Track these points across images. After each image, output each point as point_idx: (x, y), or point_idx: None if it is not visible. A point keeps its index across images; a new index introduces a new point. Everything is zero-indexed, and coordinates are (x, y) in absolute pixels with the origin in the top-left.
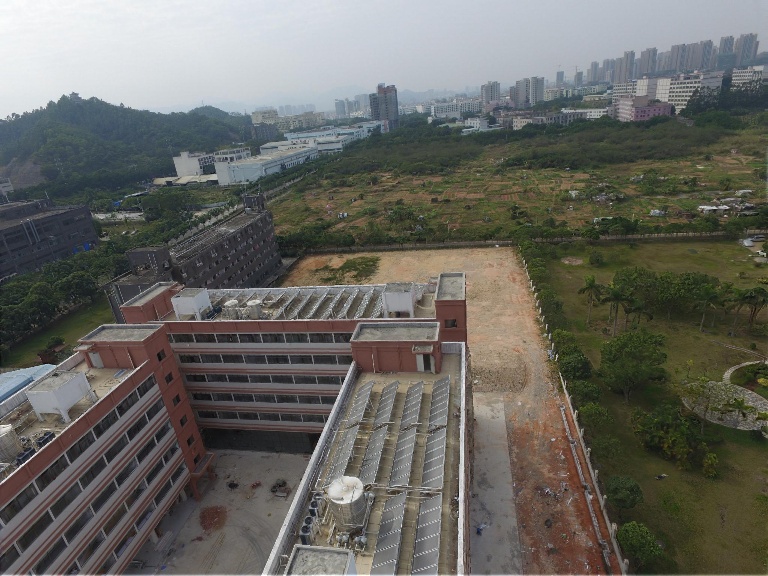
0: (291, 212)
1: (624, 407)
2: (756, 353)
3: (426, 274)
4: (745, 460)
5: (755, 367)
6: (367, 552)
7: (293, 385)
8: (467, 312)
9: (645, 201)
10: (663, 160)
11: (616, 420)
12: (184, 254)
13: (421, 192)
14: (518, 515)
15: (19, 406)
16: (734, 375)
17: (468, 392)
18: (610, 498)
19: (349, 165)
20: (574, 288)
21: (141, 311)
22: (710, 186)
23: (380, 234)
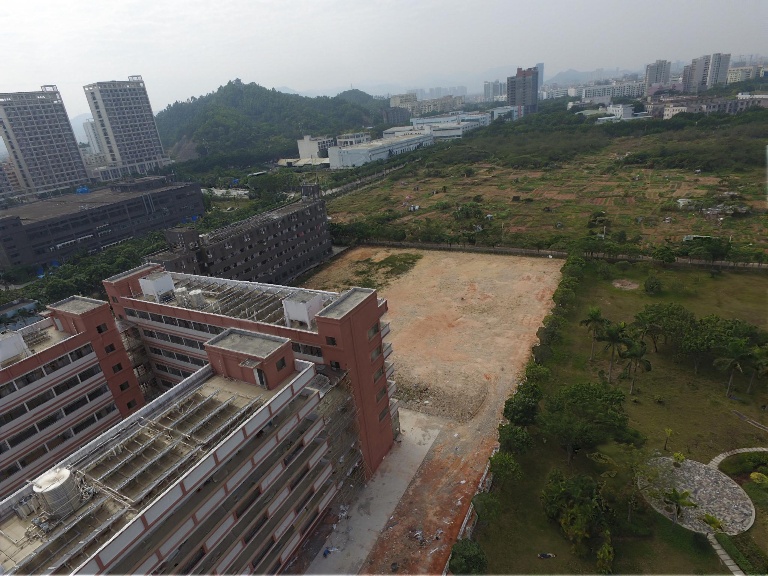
0: (371, 200)
1: (561, 466)
2: None
3: (455, 279)
4: (664, 566)
5: (765, 456)
6: (45, 539)
7: None
8: (466, 326)
9: None
10: None
11: (541, 478)
12: (216, 237)
13: (509, 188)
14: (374, 549)
15: None
16: (727, 460)
17: (334, 413)
18: (449, 561)
19: (454, 154)
20: (604, 317)
21: (114, 287)
22: None
23: (437, 231)
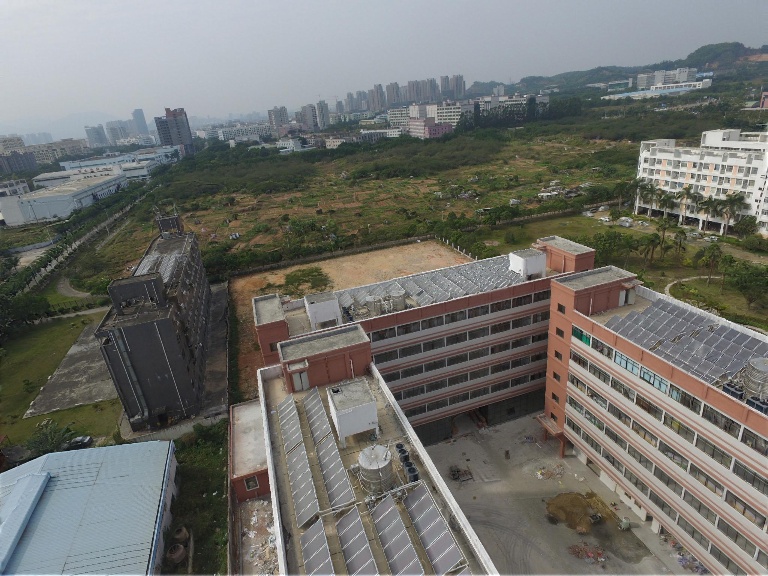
0: None
1: None
2: (667, 278)
3: (382, 273)
4: None
5: None
6: None
7: (445, 368)
8: None
9: (496, 195)
10: (476, 166)
11: None
12: (166, 283)
13: (295, 207)
14: None
15: (303, 442)
16: (673, 292)
17: None
18: None
19: (184, 189)
20: None
21: (284, 325)
22: (528, 181)
23: None
